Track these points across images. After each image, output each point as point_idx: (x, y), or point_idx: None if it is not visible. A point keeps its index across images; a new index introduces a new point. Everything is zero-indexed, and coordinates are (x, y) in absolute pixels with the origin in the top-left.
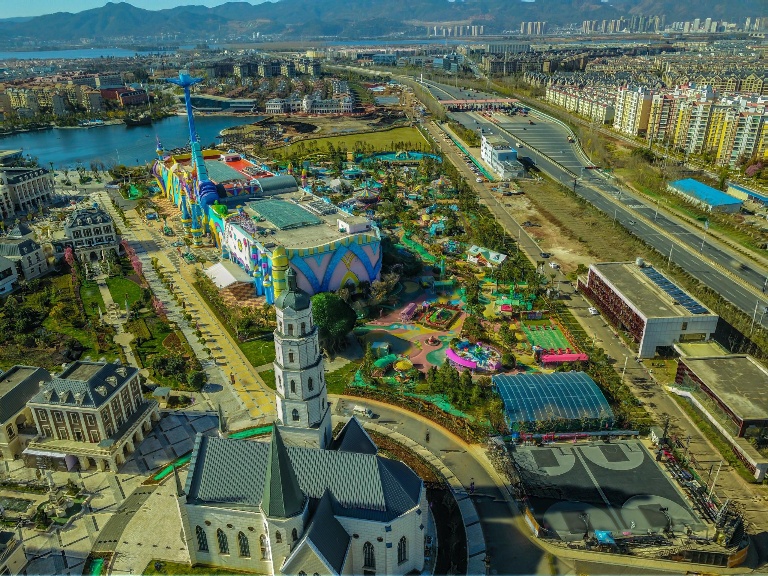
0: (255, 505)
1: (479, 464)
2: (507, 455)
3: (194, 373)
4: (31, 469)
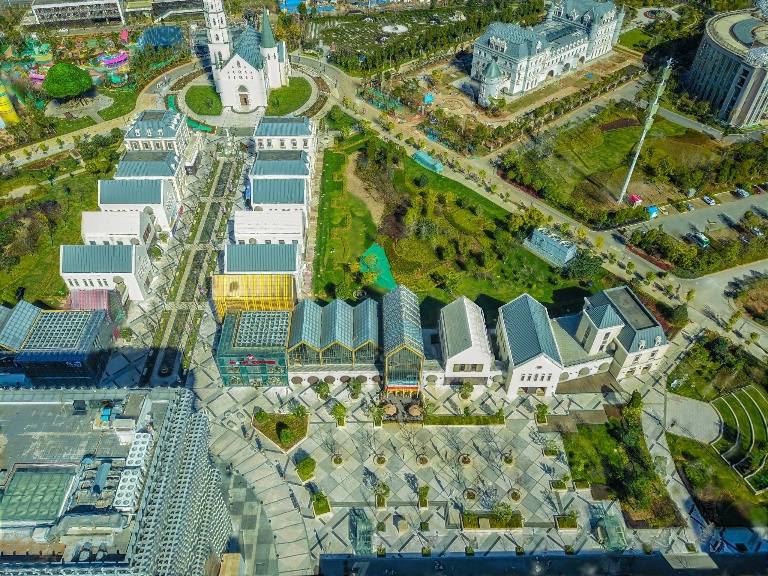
0: (262, 60)
1: (205, 60)
2: (201, 54)
3: (115, 128)
4: (197, 173)
